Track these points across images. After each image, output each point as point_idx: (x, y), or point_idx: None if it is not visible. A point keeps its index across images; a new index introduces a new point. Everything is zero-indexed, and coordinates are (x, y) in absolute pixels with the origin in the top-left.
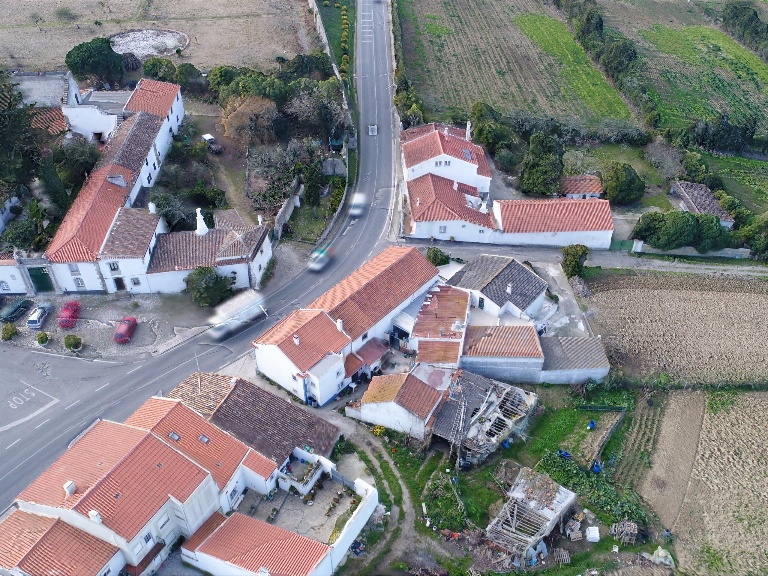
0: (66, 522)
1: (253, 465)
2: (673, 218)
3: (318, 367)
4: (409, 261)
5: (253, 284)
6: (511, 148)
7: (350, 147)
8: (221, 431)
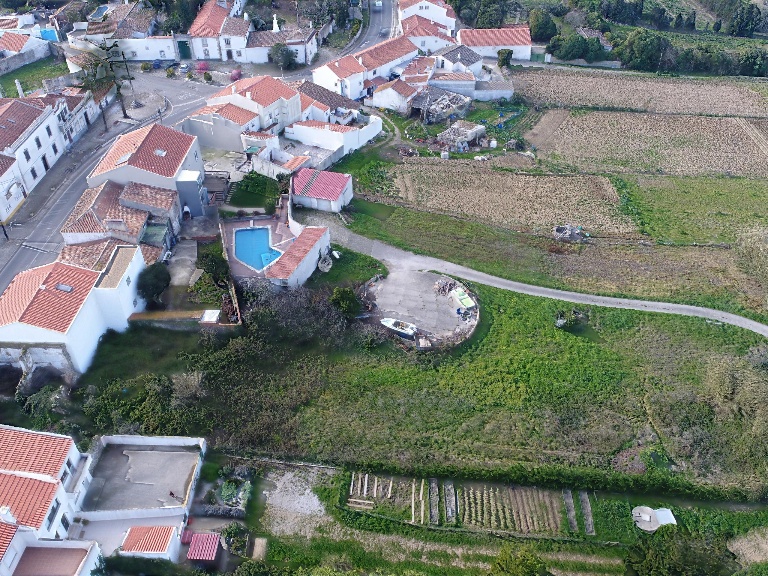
0: (233, 104)
1: (318, 106)
2: (569, 37)
3: (349, 77)
4: (401, 41)
5: (307, 61)
6: (472, 9)
7: (364, 8)
8: (300, 92)
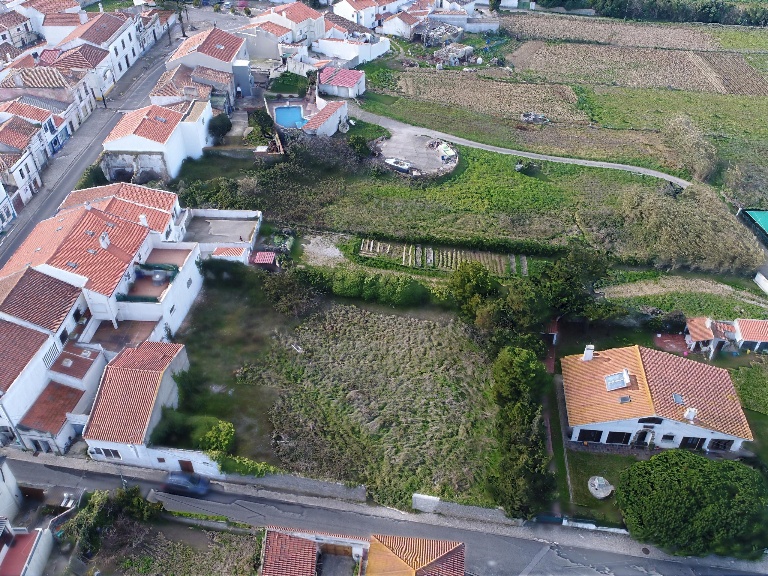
0: (272, 22)
1: (338, 29)
2: None
3: (364, 10)
4: None
5: (329, 2)
6: None
7: None
8: None
